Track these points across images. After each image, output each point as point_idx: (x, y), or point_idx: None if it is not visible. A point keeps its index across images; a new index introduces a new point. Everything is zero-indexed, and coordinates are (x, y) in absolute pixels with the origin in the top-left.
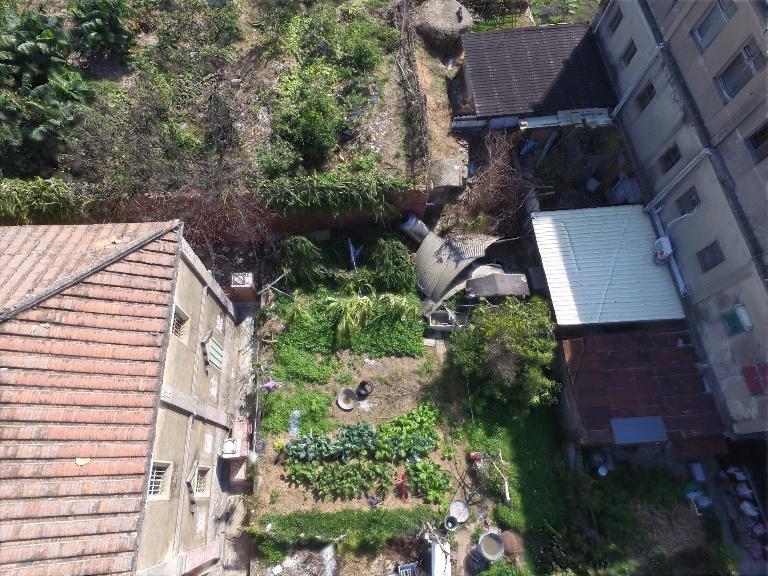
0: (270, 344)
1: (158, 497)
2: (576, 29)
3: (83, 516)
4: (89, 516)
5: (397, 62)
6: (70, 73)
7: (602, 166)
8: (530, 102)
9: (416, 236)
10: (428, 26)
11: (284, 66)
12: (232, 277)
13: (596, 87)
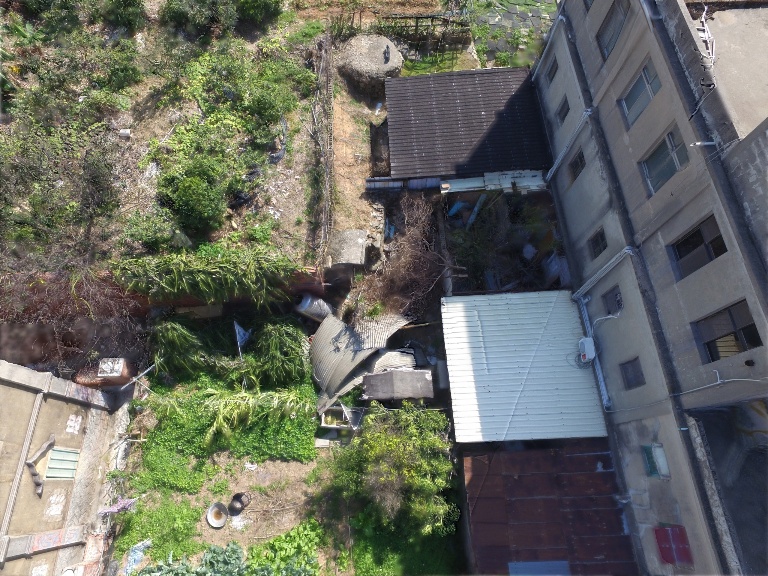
0: (139, 442)
1: None
2: (514, 74)
3: None
4: None
5: (311, 109)
6: None
7: (537, 234)
8: (453, 162)
9: (314, 317)
10: (350, 67)
11: (180, 114)
12: (100, 363)
13: (530, 145)
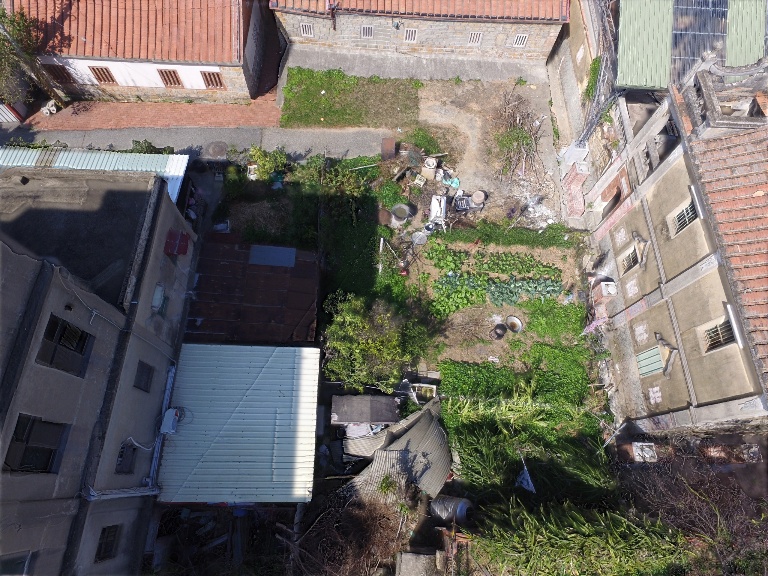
0: None
1: (678, 210)
2: None
3: None
4: None
5: None
6: None
7: None
8: None
9: None
10: None
11: None
12: None
13: None
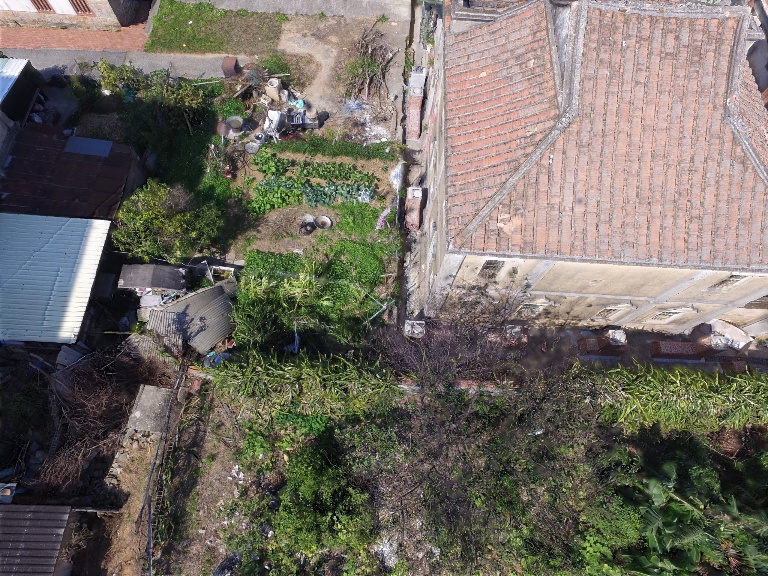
0: None
1: None
2: None
3: None
4: None
5: None
6: None
7: None
8: None
9: None
10: None
11: None
12: None
13: None
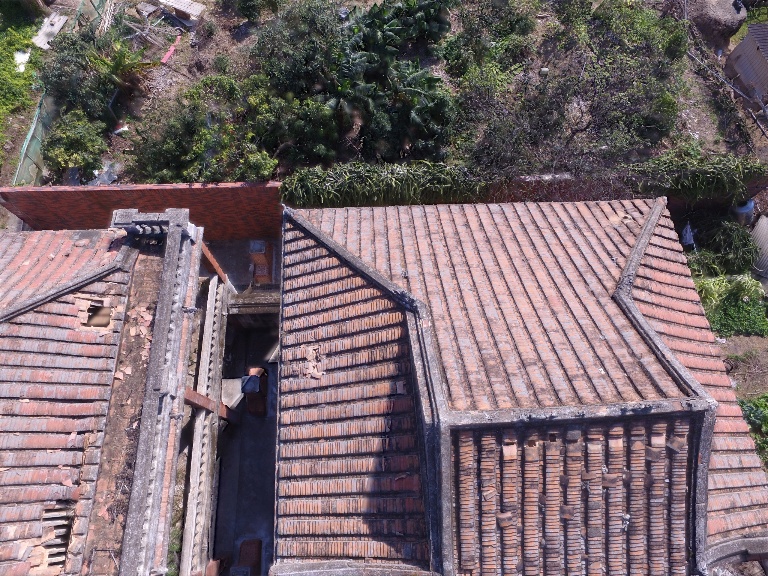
0: None
1: None
2: None
3: (734, 469)
4: (738, 470)
5: None
6: (397, 62)
7: None
8: None
9: (744, 220)
10: (708, 17)
11: (587, 55)
12: None
13: None
